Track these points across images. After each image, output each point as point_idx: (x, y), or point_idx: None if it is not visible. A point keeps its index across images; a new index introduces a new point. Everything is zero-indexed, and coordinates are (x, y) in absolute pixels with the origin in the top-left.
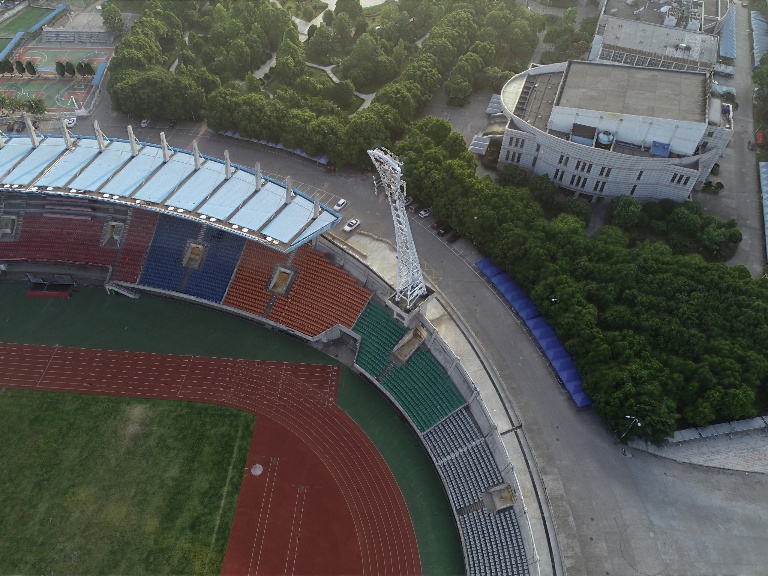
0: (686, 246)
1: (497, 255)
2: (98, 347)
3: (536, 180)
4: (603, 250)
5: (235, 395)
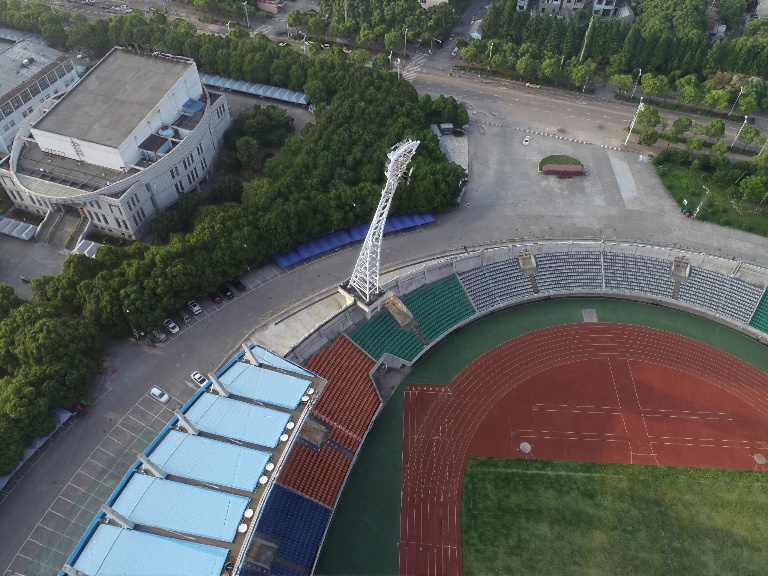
0: (282, 134)
1: (287, 242)
2: None
3: (185, 203)
4: (300, 168)
5: (448, 482)
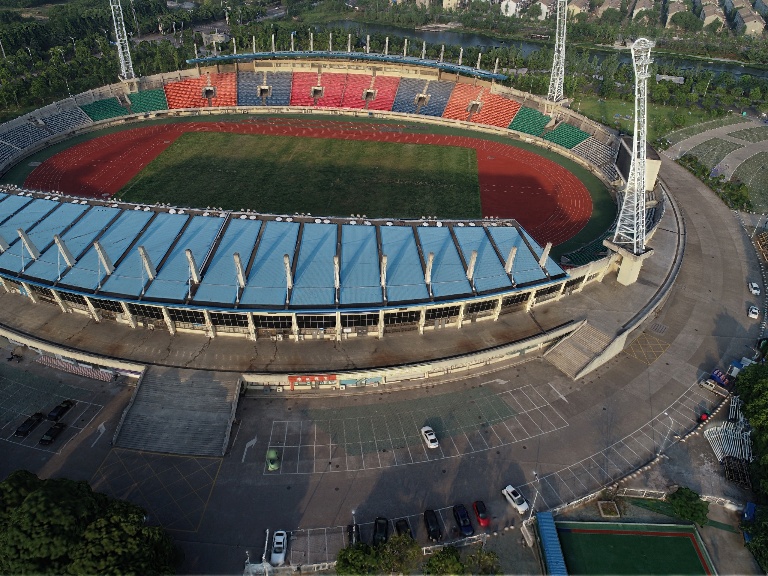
0: None
1: None
2: None
3: None
4: None
5: None
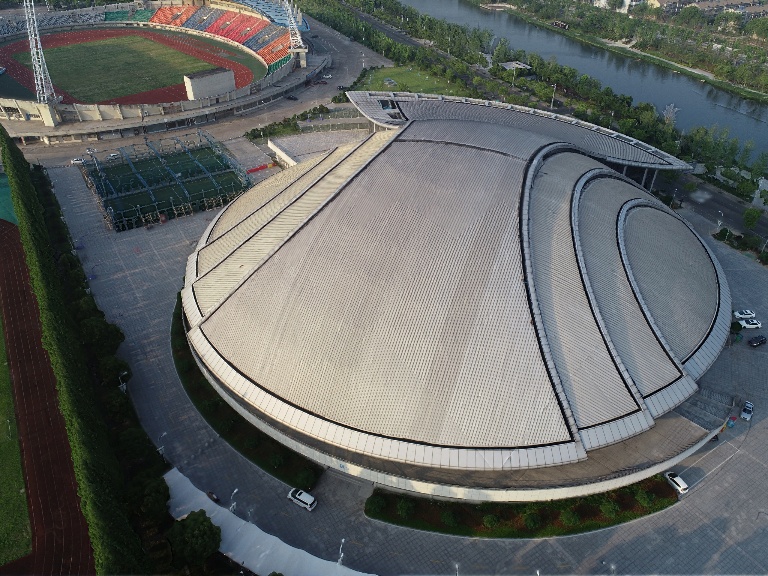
0: None
1: None
2: (5, 74)
3: None
4: None
5: None
